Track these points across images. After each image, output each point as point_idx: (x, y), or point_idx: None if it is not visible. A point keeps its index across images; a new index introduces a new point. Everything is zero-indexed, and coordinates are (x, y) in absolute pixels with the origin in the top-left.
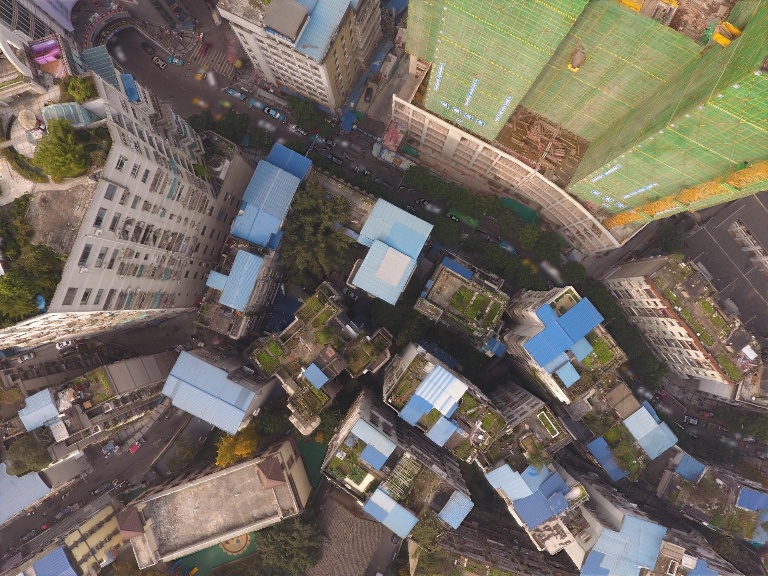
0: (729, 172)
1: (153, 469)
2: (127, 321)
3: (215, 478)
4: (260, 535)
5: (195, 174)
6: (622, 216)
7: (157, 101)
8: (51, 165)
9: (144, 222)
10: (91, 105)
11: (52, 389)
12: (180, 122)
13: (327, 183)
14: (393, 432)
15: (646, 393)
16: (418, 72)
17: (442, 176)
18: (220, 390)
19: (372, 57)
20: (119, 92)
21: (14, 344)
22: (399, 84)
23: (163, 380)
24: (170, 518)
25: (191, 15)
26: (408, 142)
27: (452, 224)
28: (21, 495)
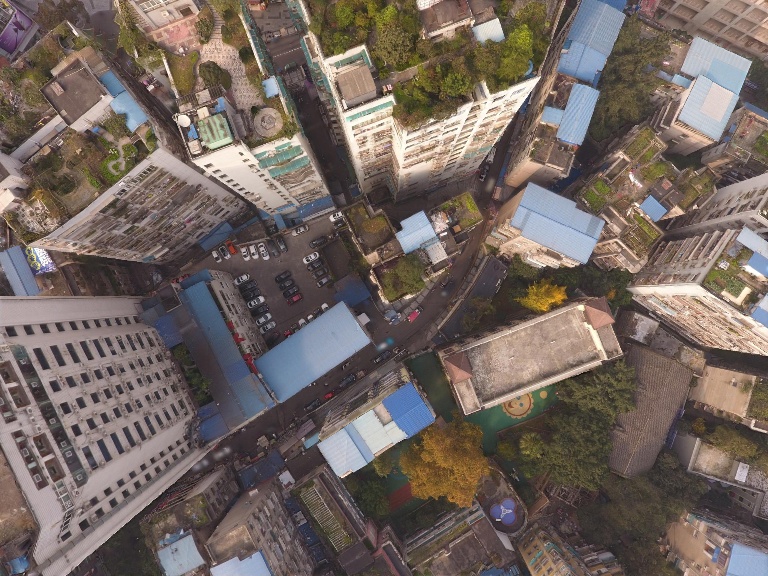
0: None
1: (442, 332)
2: (472, 155)
3: (529, 327)
4: (575, 382)
5: None
6: None
7: None
8: None
9: None
10: None
11: None
12: None
13: None
14: None
15: None
16: None
17: None
18: (570, 219)
19: None
20: None
21: (419, 152)
22: None
23: None
24: (485, 367)
25: None
26: None
27: None
28: (342, 346)
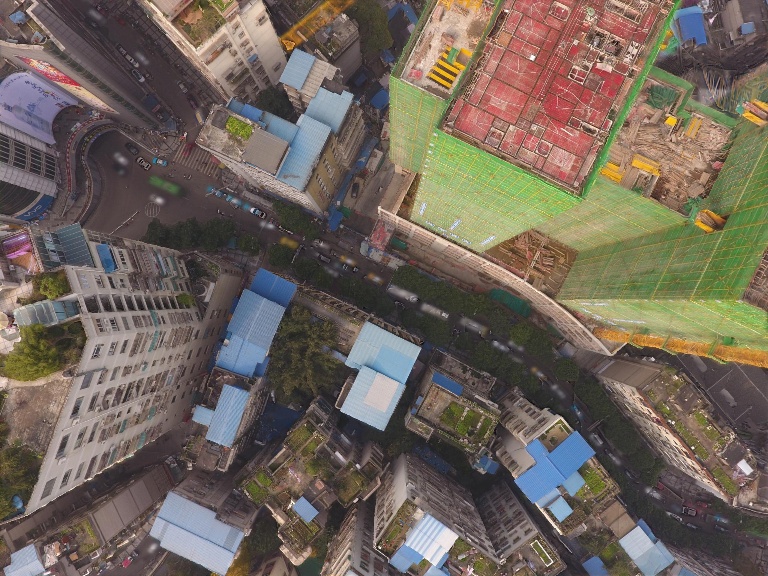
0: (716, 344)
1: None
2: None
3: None
4: None
5: (179, 307)
6: (612, 333)
7: (136, 255)
8: (23, 375)
9: (125, 384)
10: (64, 298)
11: (38, 542)
12: (161, 261)
13: (313, 304)
14: (384, 571)
15: (643, 488)
16: (404, 173)
17: (431, 271)
18: (208, 531)
19: (357, 154)
20: (94, 270)
21: None
22: (386, 177)
23: (153, 502)
24: None
25: (174, 113)
26: (396, 235)
27: (442, 325)
28: None
